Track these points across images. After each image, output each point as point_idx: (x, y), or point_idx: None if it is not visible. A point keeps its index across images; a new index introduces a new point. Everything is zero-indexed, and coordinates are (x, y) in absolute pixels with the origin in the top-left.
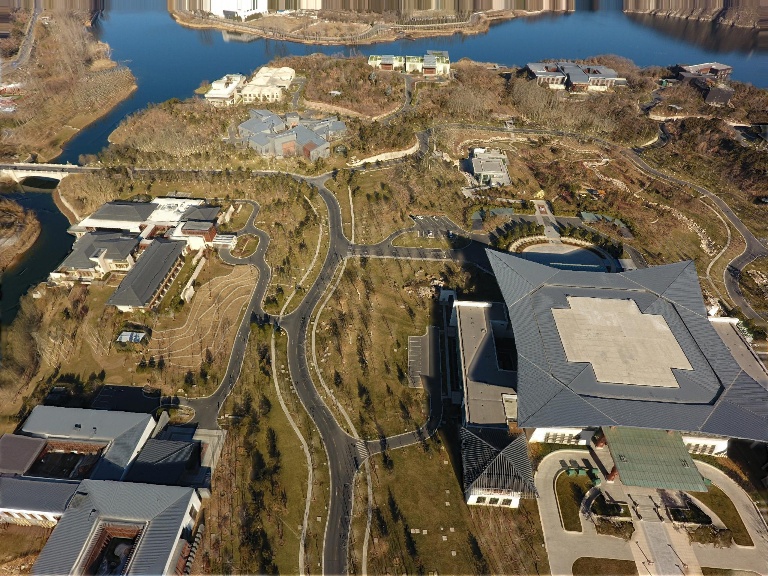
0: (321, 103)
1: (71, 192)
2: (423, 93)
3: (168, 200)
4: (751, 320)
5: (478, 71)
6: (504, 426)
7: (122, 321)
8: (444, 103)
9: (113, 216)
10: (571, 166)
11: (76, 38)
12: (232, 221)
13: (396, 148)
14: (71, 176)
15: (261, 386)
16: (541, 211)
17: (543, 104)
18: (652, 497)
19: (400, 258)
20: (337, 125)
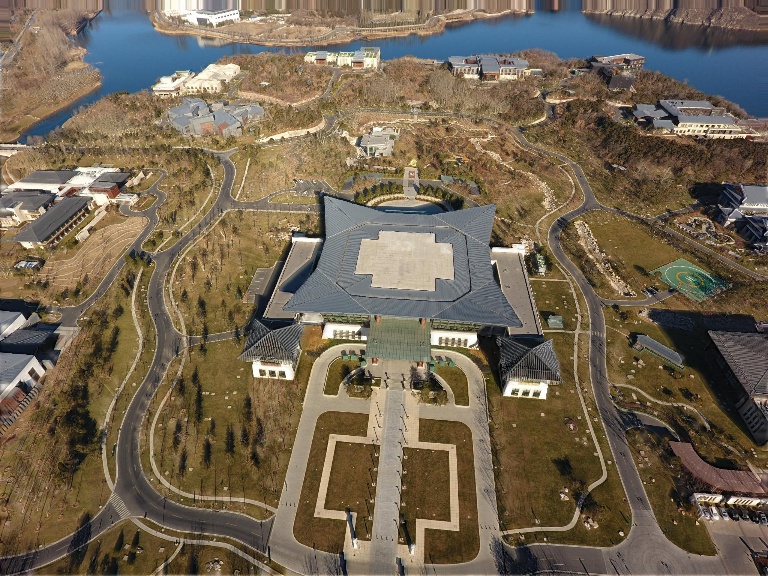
0: (251, 93)
1: (15, 165)
2: (347, 83)
3: (89, 168)
4: (550, 255)
5: (405, 64)
6: (291, 320)
7: (24, 255)
8: (361, 91)
9: (38, 180)
10: (455, 141)
11: (57, 44)
12: (140, 185)
13: (299, 127)
14: (19, 153)
15: (120, 299)
16: (410, 176)
17: (452, 91)
18: (404, 374)
19: (271, 211)
20: (256, 110)
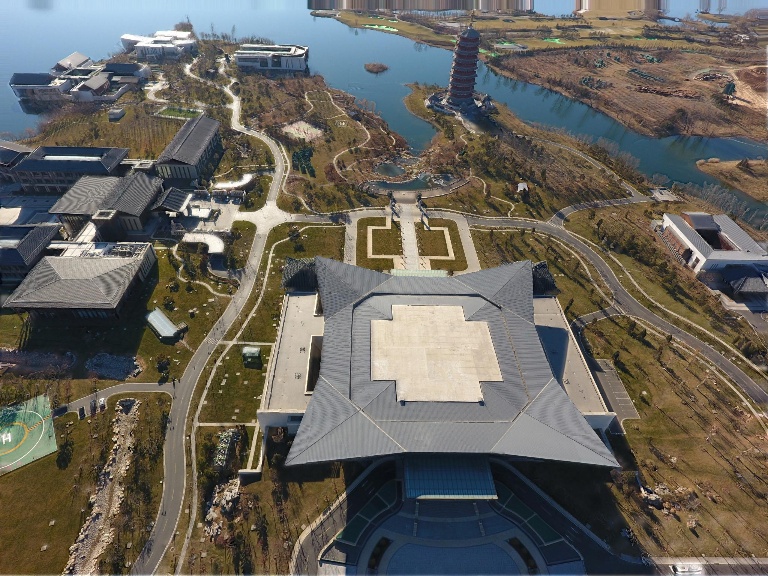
0: None
1: None
2: None
3: None
4: None
5: None
6: None
7: None
8: None
9: None
10: None
11: None
12: None
13: None
14: None
15: None
16: None
17: None
18: None
19: (747, 560)
20: None
